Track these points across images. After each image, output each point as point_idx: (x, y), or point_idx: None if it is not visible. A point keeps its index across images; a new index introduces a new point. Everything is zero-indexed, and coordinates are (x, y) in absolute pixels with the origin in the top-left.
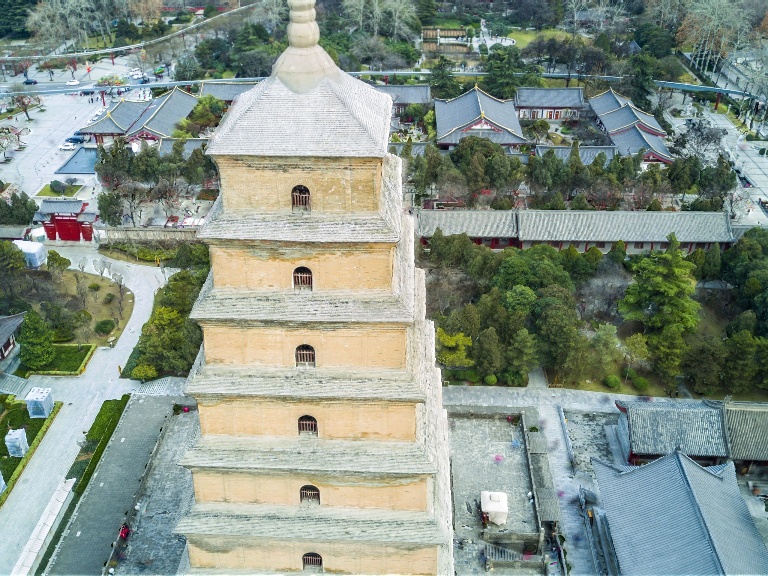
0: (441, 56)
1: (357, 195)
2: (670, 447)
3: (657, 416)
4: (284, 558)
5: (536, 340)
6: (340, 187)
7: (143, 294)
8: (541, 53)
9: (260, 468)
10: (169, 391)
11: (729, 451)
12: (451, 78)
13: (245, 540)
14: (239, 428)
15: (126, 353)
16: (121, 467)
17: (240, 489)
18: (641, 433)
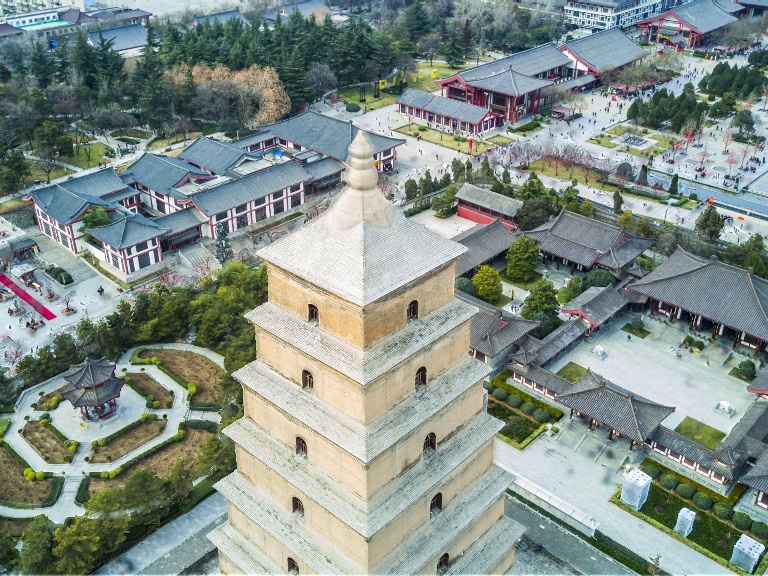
0: None
1: None
2: None
3: None
4: None
5: None
6: None
7: None
8: None
9: None
10: None
11: None
12: None
13: None
14: None
15: None
16: None
17: None
18: None
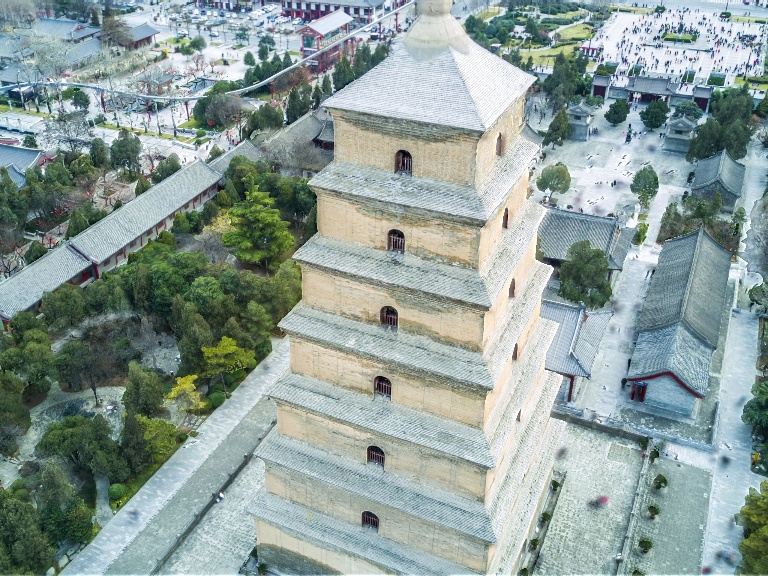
0: None
1: None
2: None
3: None
4: None
5: None
6: None
7: None
8: None
9: None
10: None
11: None
12: None
13: None
14: None
15: None
16: None
17: None
18: None
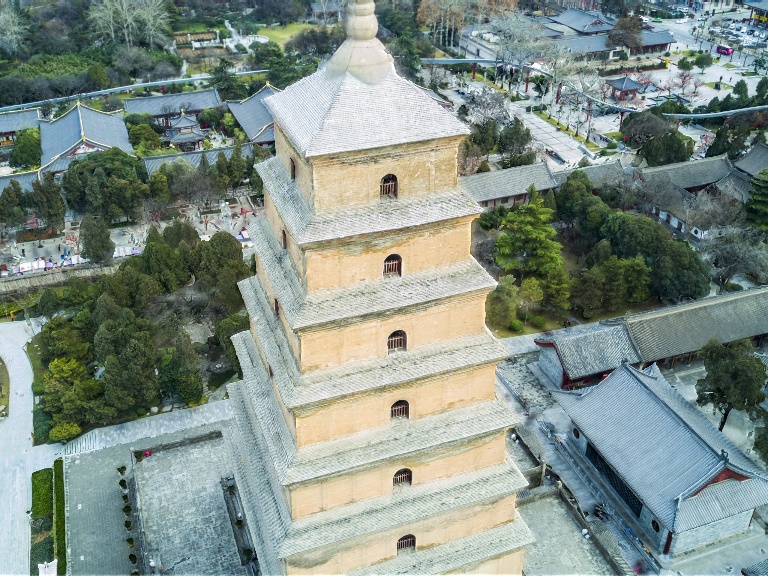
0: (221, 58)
1: (440, 175)
2: (597, 366)
3: (579, 343)
4: (380, 550)
5: None
6: (425, 170)
7: (11, 353)
8: (314, 45)
9: (362, 465)
10: (103, 443)
11: (641, 357)
12: (235, 79)
13: (344, 544)
14: (335, 431)
15: (26, 419)
16: (94, 534)
17: (337, 493)
18: (571, 360)
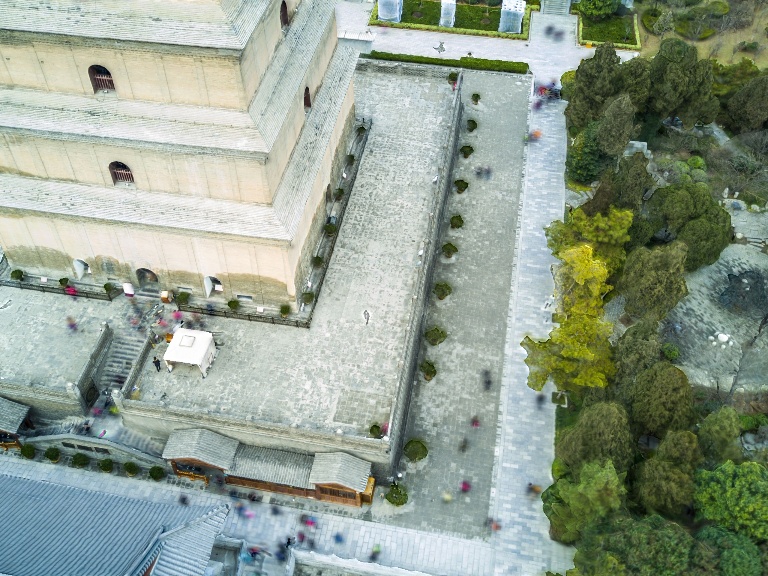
0: None
1: None
2: None
3: None
4: None
5: (603, 510)
6: None
7: None
8: None
9: None
10: (538, 101)
11: None
12: None
13: None
14: None
15: None
16: None
17: None
18: None
